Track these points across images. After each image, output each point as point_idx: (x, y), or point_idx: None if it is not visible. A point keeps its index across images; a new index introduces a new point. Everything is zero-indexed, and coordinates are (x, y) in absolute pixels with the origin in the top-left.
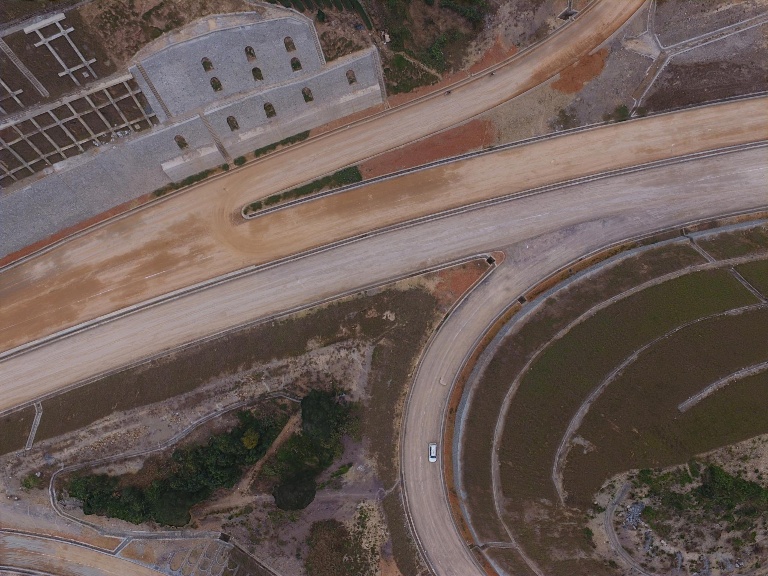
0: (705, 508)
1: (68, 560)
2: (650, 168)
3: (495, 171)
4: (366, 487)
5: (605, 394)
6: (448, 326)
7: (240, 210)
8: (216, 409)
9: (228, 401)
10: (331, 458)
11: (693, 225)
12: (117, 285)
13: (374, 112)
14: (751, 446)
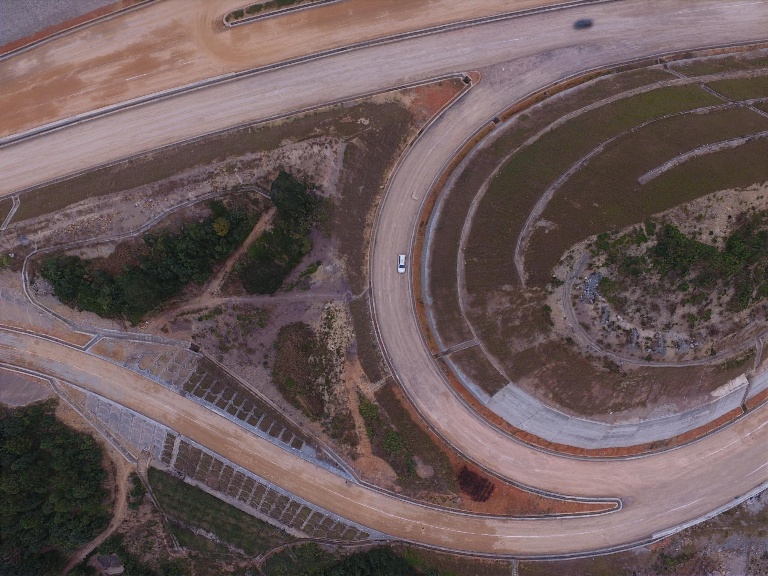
0: (660, 272)
1: (39, 355)
2: None
3: None
4: (334, 287)
5: (569, 181)
6: (422, 142)
7: (222, 18)
8: (189, 198)
9: (201, 191)
10: (300, 254)
11: (668, 56)
12: (98, 85)
13: None
14: (706, 204)
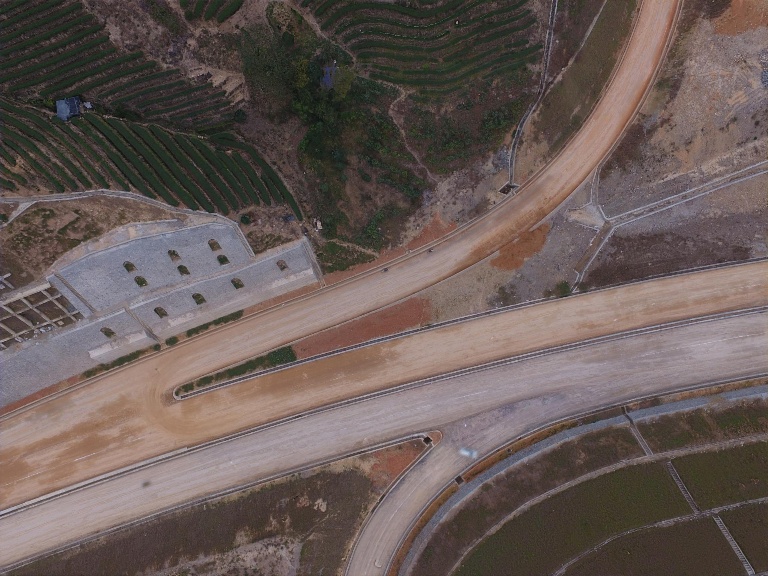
0: None
1: None
2: (592, 344)
3: (433, 348)
4: None
5: None
6: (384, 507)
7: (172, 391)
8: None
9: None
10: None
11: (635, 403)
12: (46, 468)
13: (309, 291)
14: None
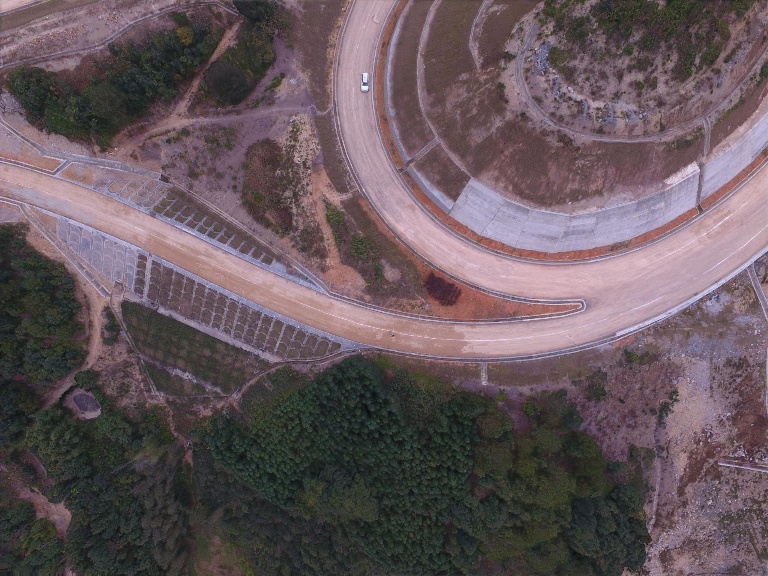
0: (605, 32)
1: (8, 181)
2: None
3: None
4: (298, 100)
5: None
6: None
7: None
8: (152, 11)
9: (164, 3)
10: (264, 65)
11: None
12: None
13: None
14: None
